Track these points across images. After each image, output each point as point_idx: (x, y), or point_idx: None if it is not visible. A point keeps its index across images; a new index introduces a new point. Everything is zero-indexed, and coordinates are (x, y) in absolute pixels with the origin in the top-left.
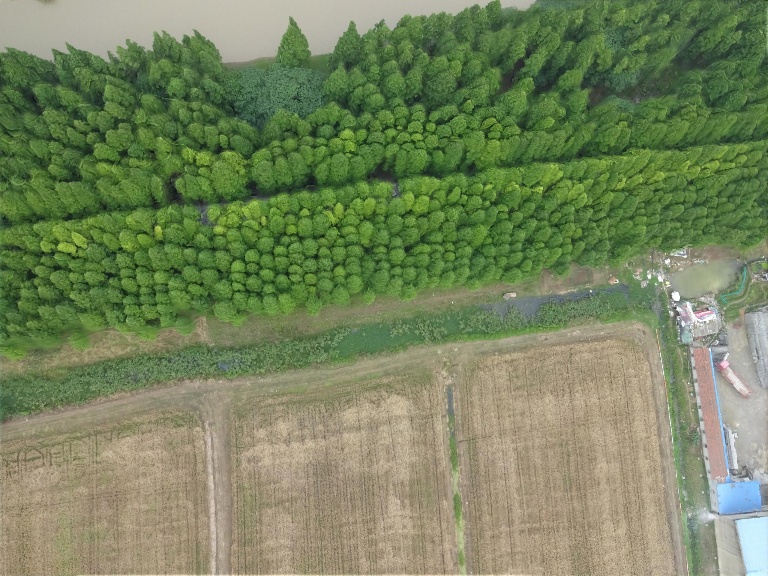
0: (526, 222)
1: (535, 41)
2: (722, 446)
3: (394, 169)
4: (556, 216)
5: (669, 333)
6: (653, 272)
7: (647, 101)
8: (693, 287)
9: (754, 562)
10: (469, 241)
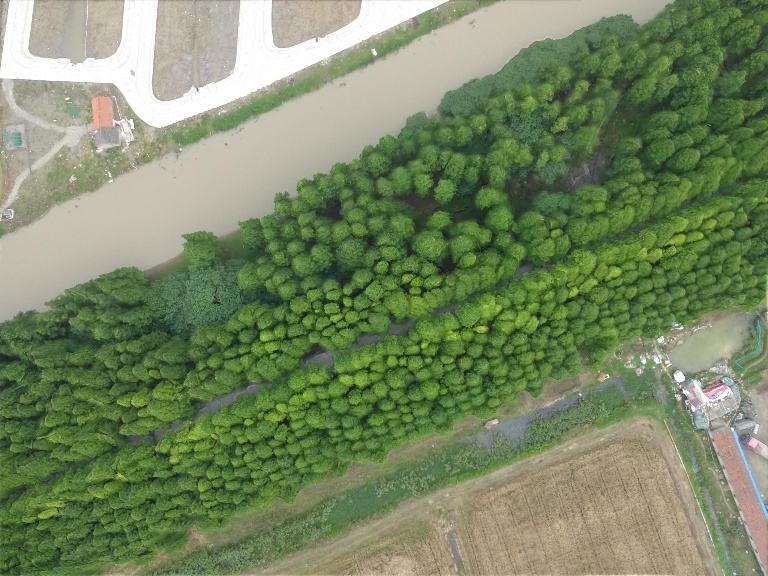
0: (477, 365)
1: (439, 166)
2: None
3: (327, 348)
4: (508, 349)
5: (681, 419)
6: (647, 356)
7: (581, 192)
8: (699, 358)
9: None
10: (423, 397)
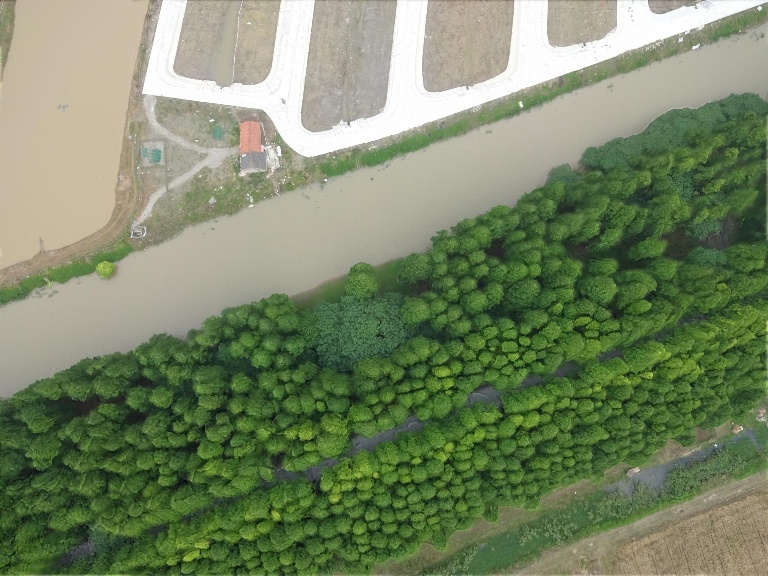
0: (642, 411)
1: (607, 216)
2: None
3: (494, 387)
4: (672, 397)
5: None
6: None
7: (738, 249)
8: None
9: None
10: None
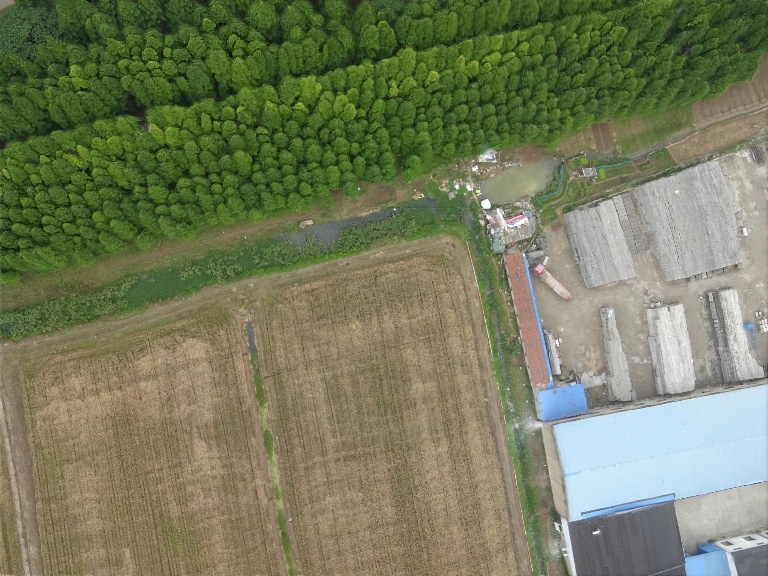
0: (291, 142)
1: None
2: (542, 352)
3: (142, 103)
4: (323, 132)
5: (482, 243)
6: (460, 182)
7: None
8: (507, 193)
9: (573, 465)
10: (235, 170)
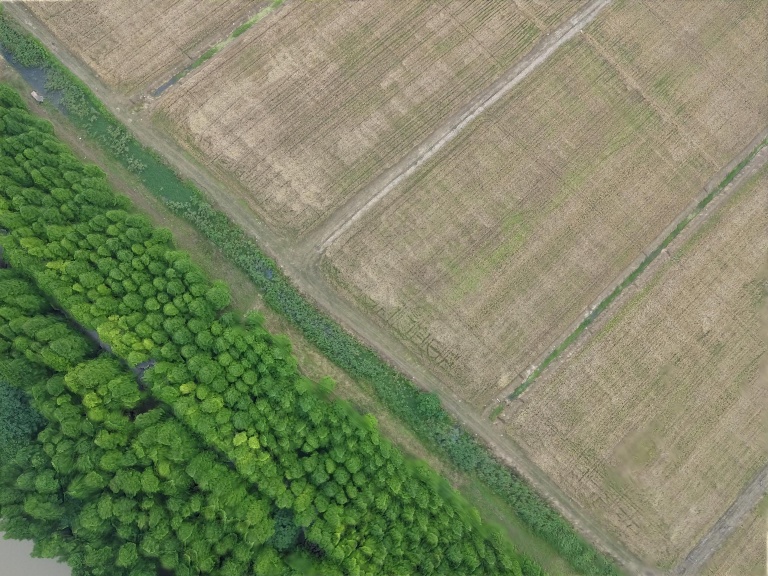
0: None
1: None
2: None
3: None
4: None
5: None
6: None
7: None
8: None
9: None
10: None
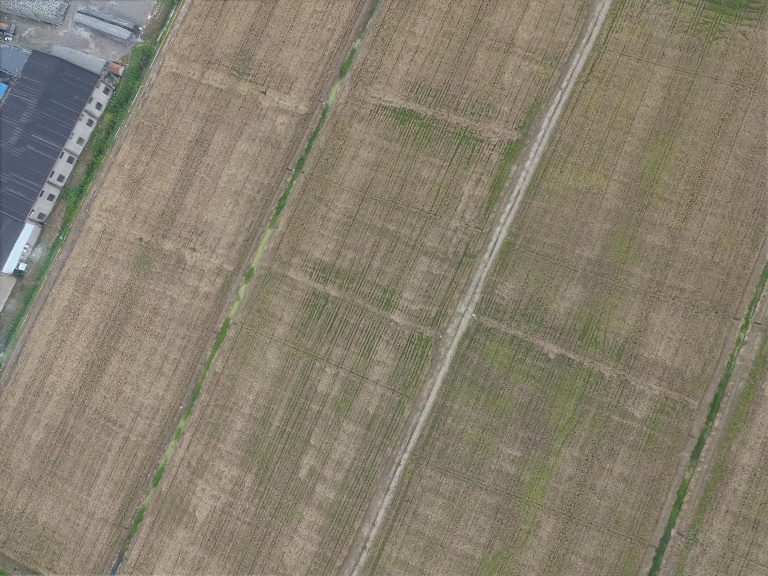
0: None
1: None
2: None
3: None
4: None
5: None
6: None
7: None
8: None
9: None
10: None
